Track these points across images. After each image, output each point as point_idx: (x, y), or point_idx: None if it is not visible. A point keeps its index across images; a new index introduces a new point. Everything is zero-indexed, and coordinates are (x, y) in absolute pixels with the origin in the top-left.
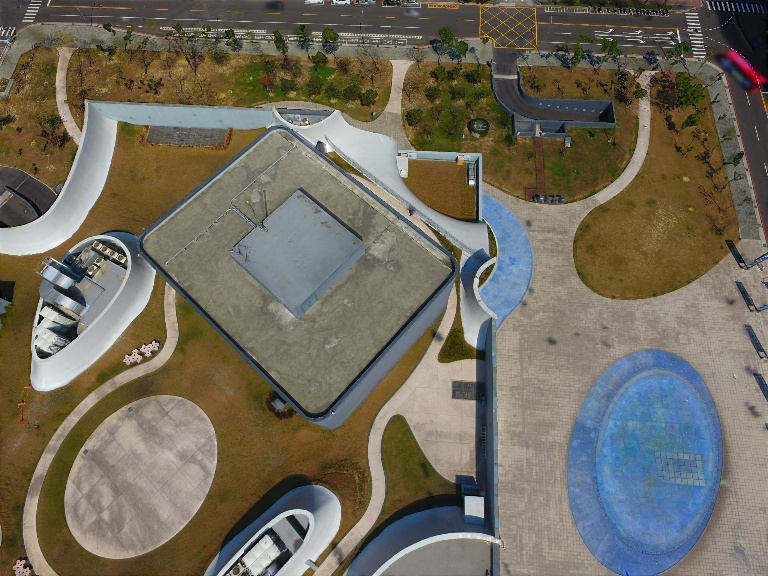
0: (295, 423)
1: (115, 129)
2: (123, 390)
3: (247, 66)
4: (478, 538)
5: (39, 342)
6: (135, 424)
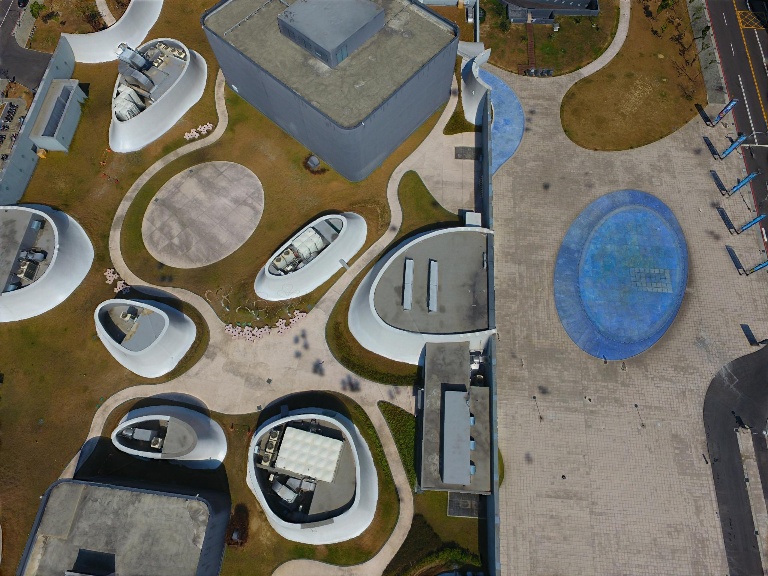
0: (327, 178)
1: None
2: (184, 158)
3: None
4: (476, 230)
5: (119, 108)
6: (196, 181)
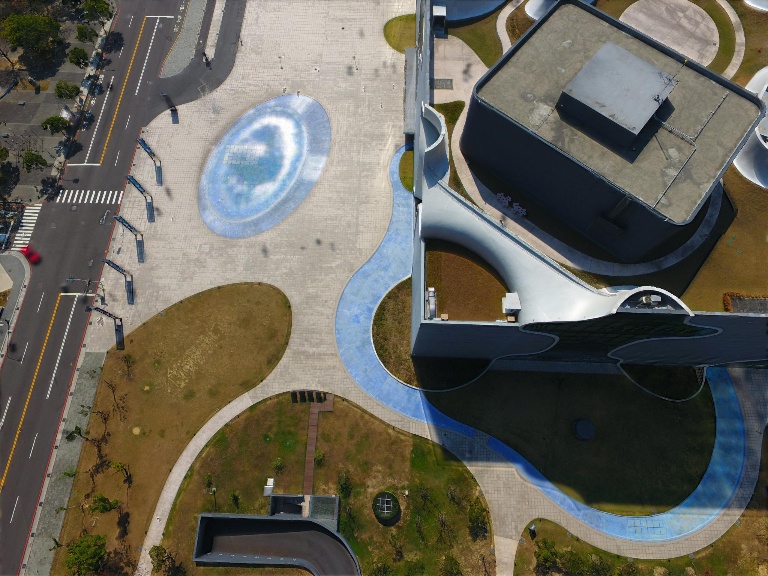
0: None
1: None
2: None
3: None
4: None
5: None
6: None
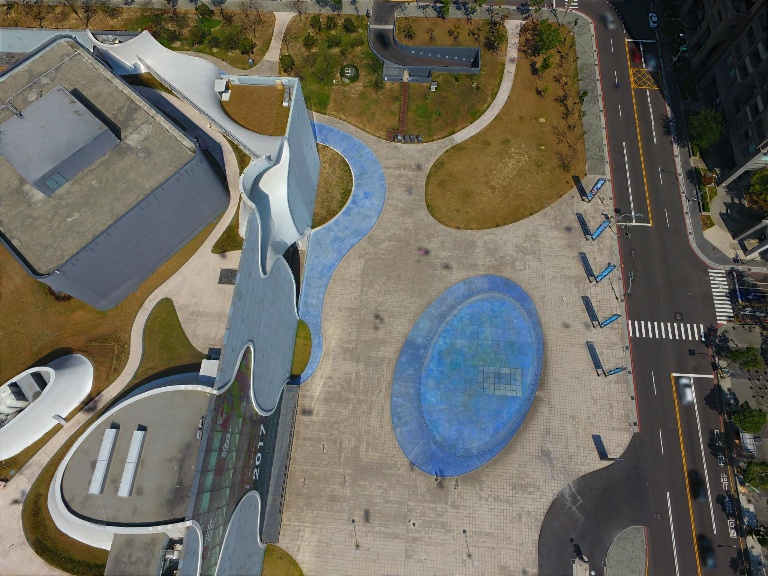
0: (73, 306)
1: None
2: None
3: (137, 19)
4: (198, 389)
5: None
6: None
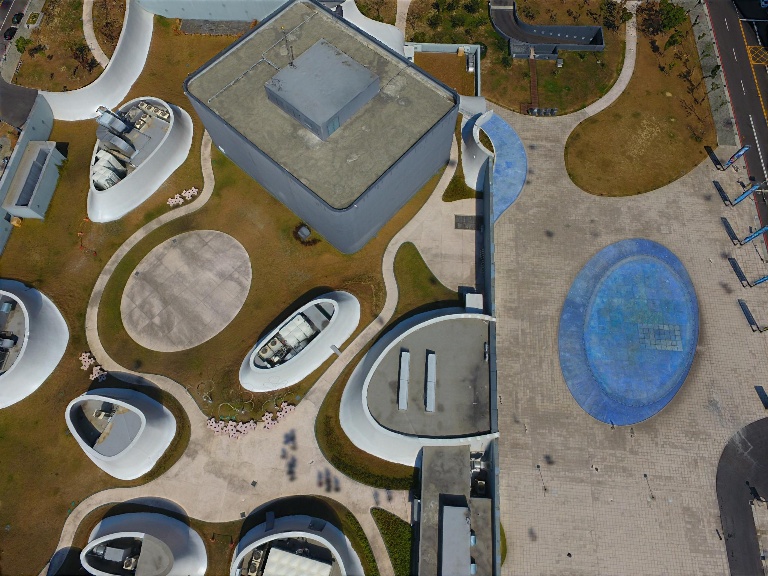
0: (318, 250)
1: (152, 21)
2: (167, 226)
3: None
4: (478, 317)
5: (97, 176)
6: (179, 252)
